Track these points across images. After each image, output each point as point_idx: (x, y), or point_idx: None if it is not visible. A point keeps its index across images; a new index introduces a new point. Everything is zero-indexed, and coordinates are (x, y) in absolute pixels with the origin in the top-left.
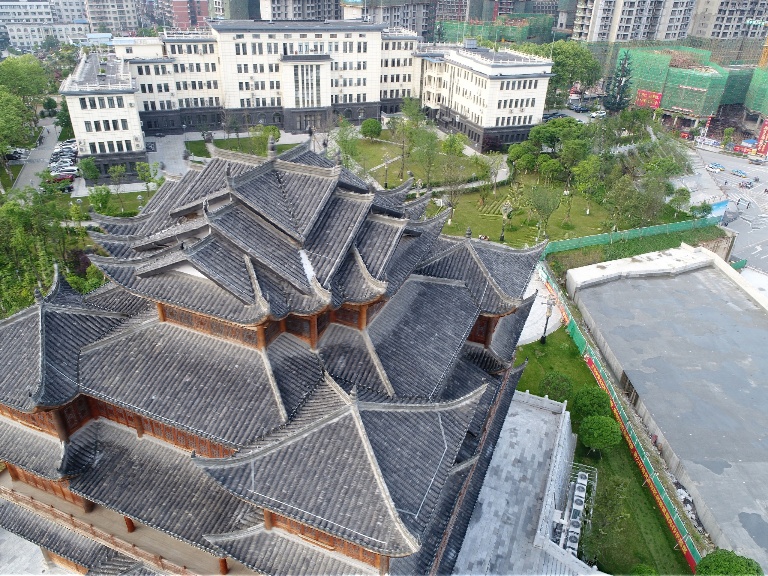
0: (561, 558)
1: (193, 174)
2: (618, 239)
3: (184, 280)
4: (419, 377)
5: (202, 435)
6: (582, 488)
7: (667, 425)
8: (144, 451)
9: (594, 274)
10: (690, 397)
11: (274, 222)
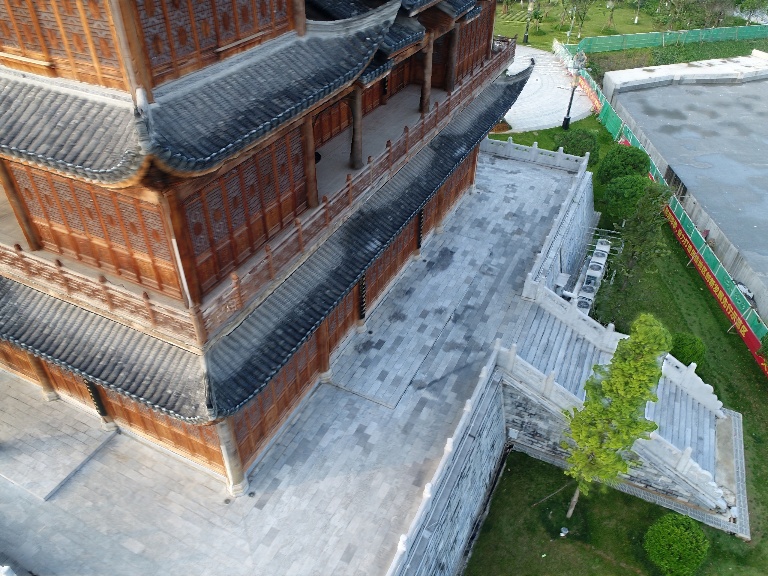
0: (561, 315)
1: None
2: (672, 42)
3: None
4: None
5: None
6: (601, 253)
7: (723, 216)
8: None
9: (639, 76)
10: (756, 191)
11: None
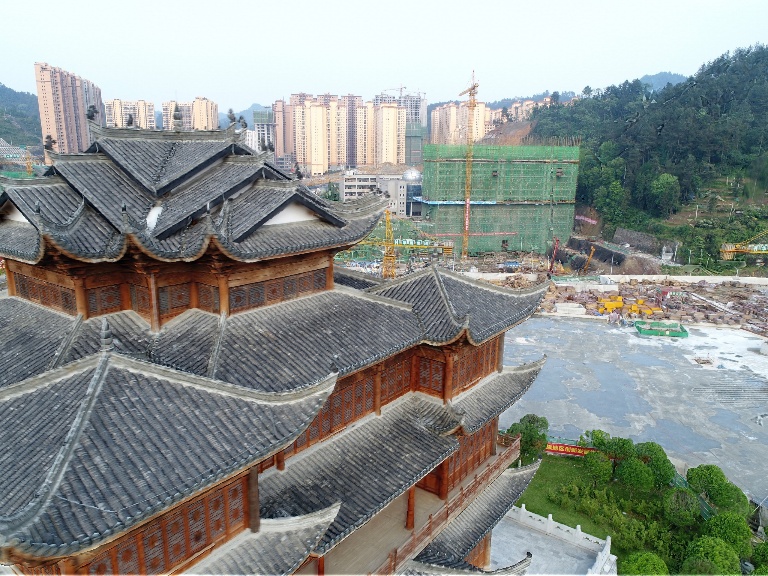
0: None
1: (74, 166)
2: None
3: (273, 231)
4: None
5: (401, 347)
6: None
7: None
8: (306, 471)
9: None
10: None
11: (276, 168)
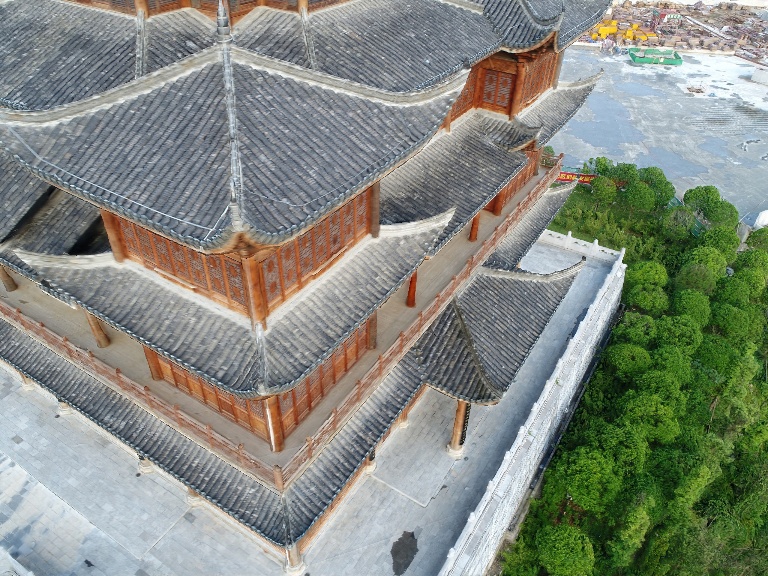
0: None
1: None
2: None
3: None
4: None
5: (485, 53)
6: None
7: None
8: (396, 185)
9: None
10: None
11: None
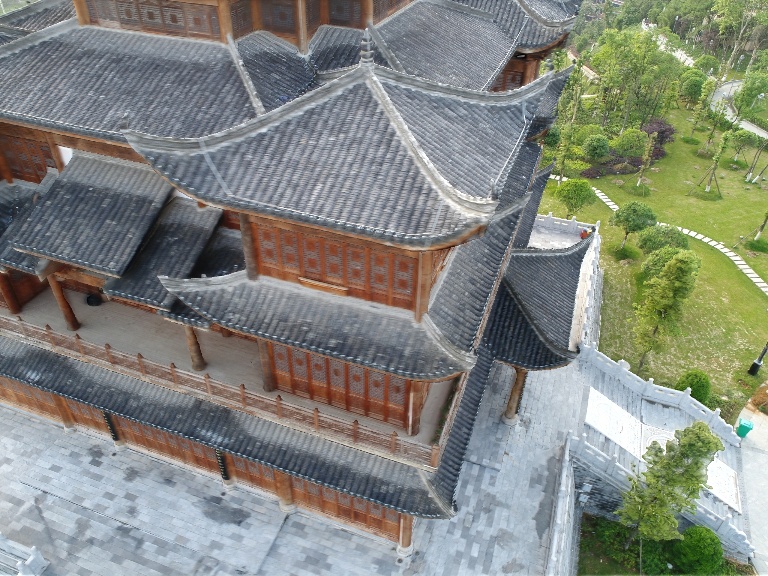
0: None
1: None
2: None
3: None
4: (4, 87)
5: None
6: None
7: None
8: None
9: None
10: None
11: None
